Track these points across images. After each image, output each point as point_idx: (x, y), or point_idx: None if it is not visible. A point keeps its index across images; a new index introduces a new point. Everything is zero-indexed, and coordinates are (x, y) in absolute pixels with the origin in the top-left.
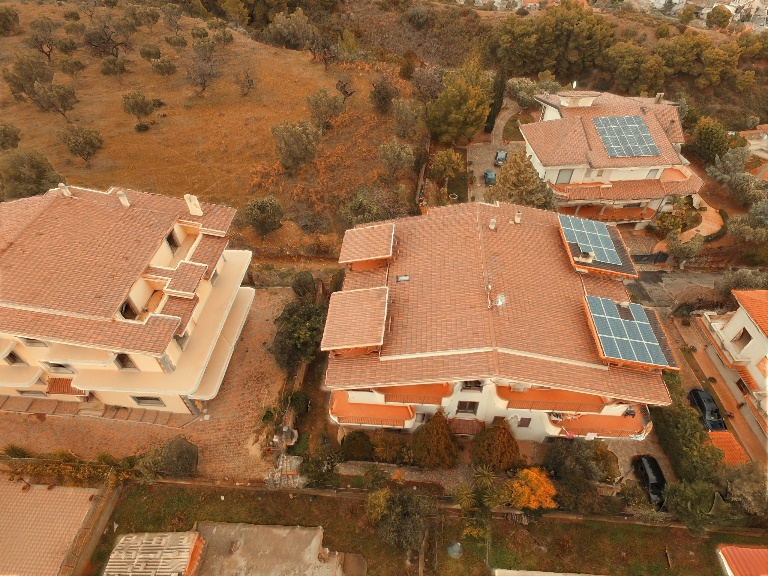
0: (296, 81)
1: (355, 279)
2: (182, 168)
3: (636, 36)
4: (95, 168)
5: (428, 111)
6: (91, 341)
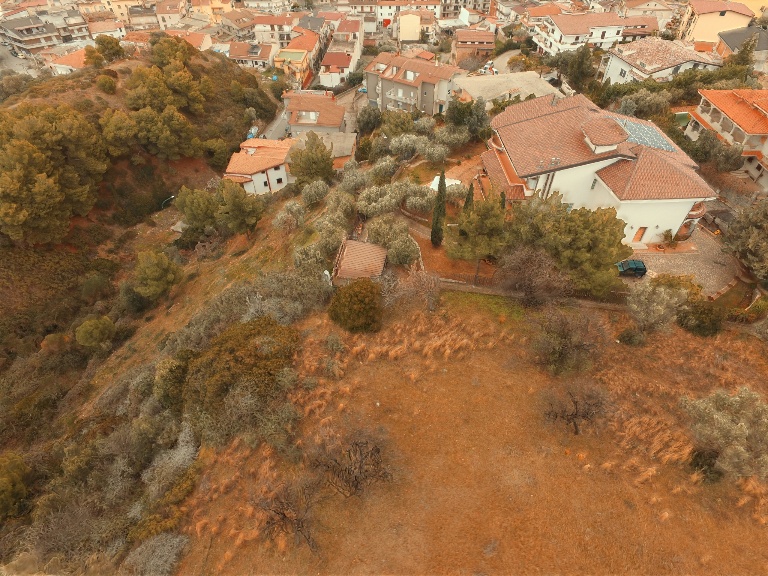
0: (472, 572)
1: None
2: None
3: (95, 104)
4: None
5: (594, 286)
6: None
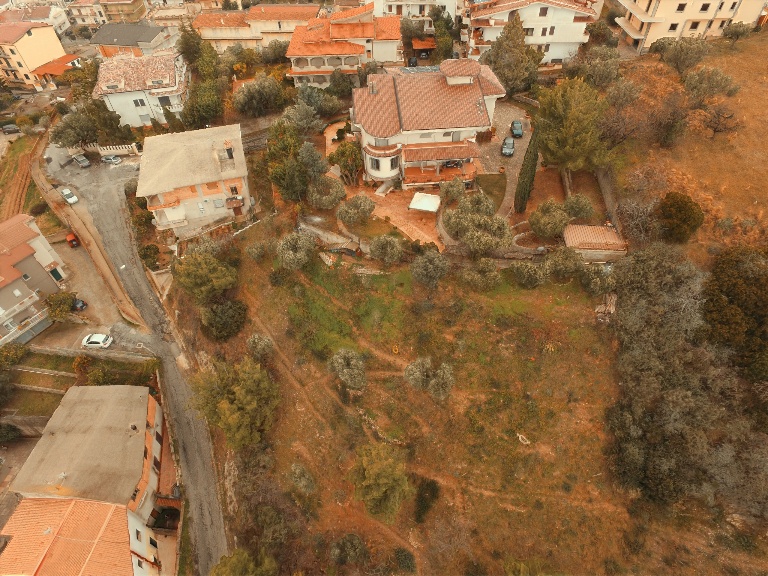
0: None
1: (582, 1)
2: (765, 66)
3: None
4: None
5: None
6: None
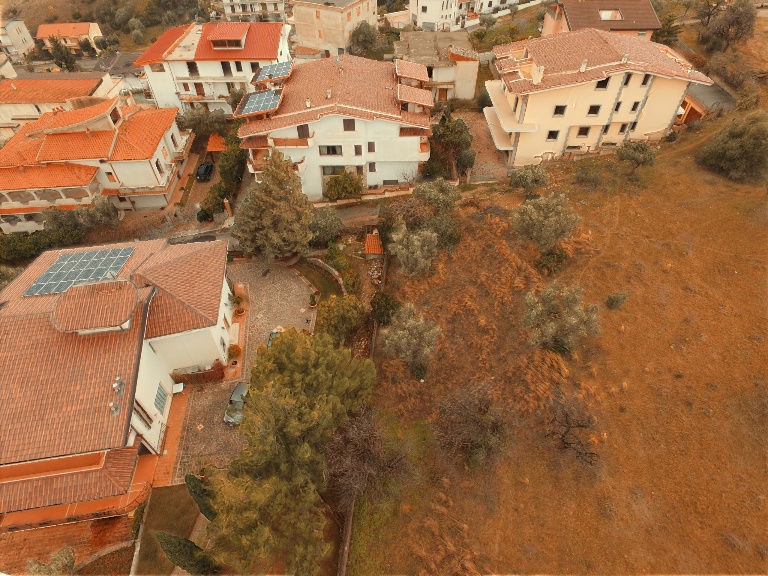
0: (764, 561)
1: None
2: (674, 227)
3: None
4: (767, 211)
5: None
6: (524, 41)
